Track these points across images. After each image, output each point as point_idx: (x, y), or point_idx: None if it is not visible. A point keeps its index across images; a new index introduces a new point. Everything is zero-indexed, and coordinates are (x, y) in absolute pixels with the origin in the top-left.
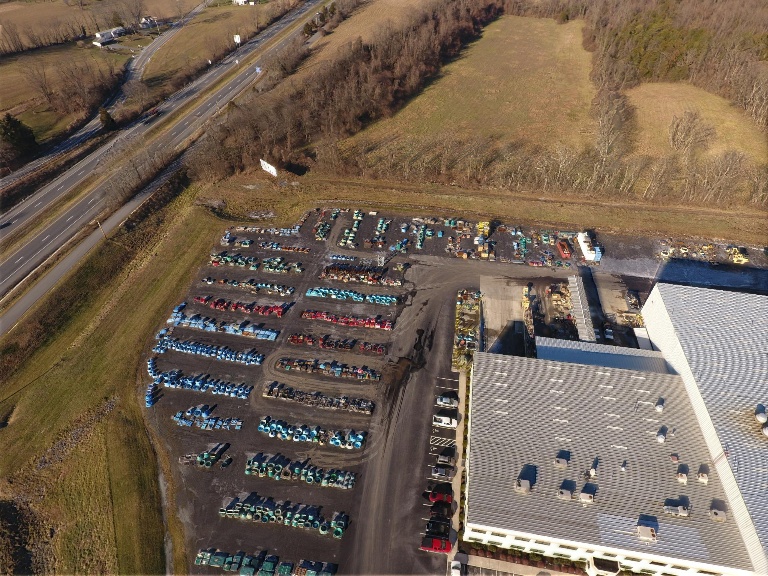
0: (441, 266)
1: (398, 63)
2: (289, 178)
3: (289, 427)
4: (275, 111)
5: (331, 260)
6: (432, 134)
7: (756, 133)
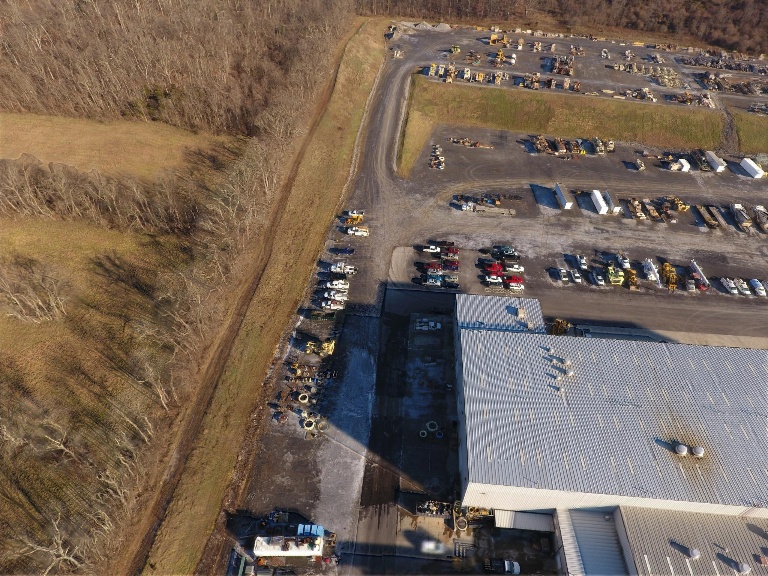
0: None
1: None
2: None
3: None
4: None
5: None
6: None
7: (62, 225)
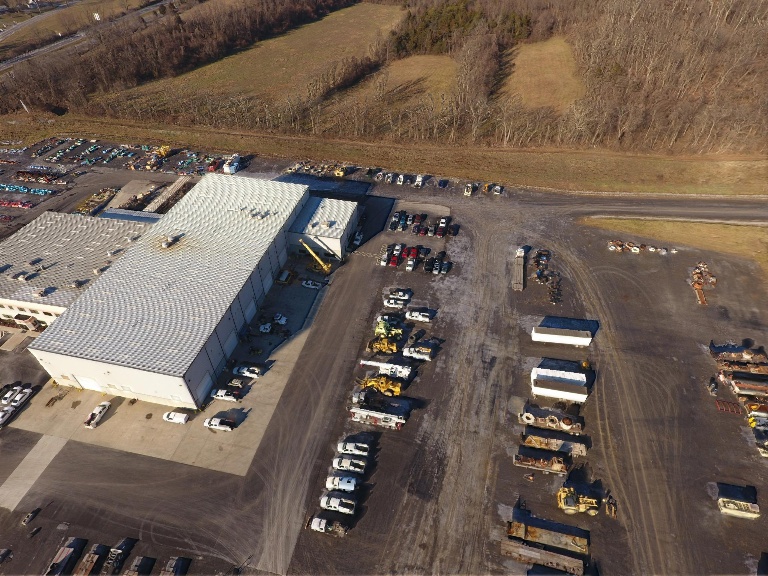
0: (109, 174)
1: (191, 33)
2: (49, 117)
3: None
4: (50, 65)
5: (29, 169)
6: (194, 89)
7: (456, 91)
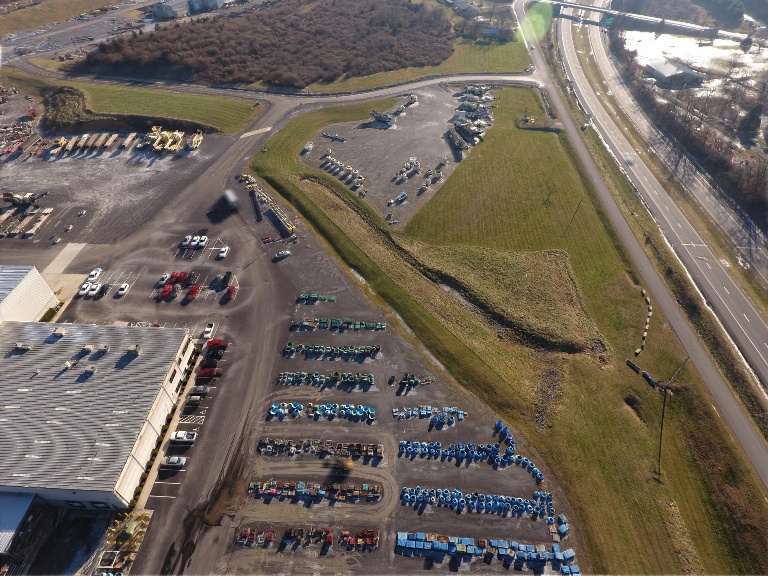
0: None
1: None
2: None
3: (345, 416)
4: None
5: None
6: None
7: None
